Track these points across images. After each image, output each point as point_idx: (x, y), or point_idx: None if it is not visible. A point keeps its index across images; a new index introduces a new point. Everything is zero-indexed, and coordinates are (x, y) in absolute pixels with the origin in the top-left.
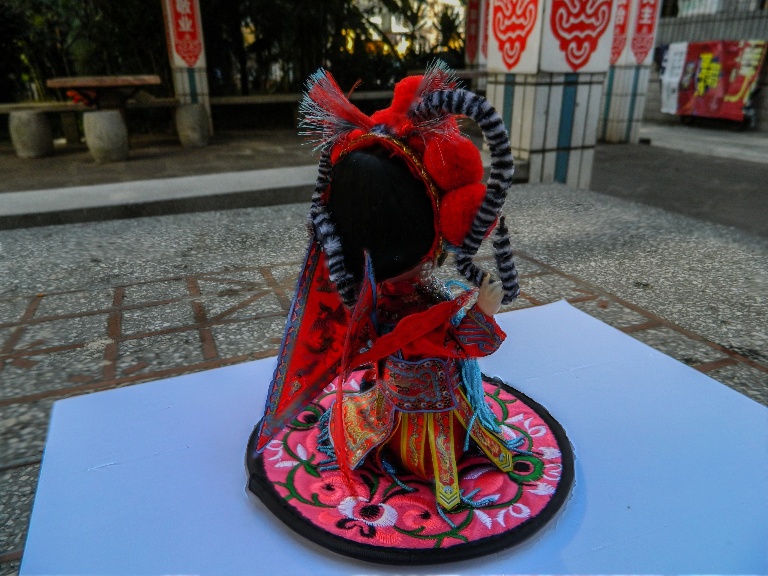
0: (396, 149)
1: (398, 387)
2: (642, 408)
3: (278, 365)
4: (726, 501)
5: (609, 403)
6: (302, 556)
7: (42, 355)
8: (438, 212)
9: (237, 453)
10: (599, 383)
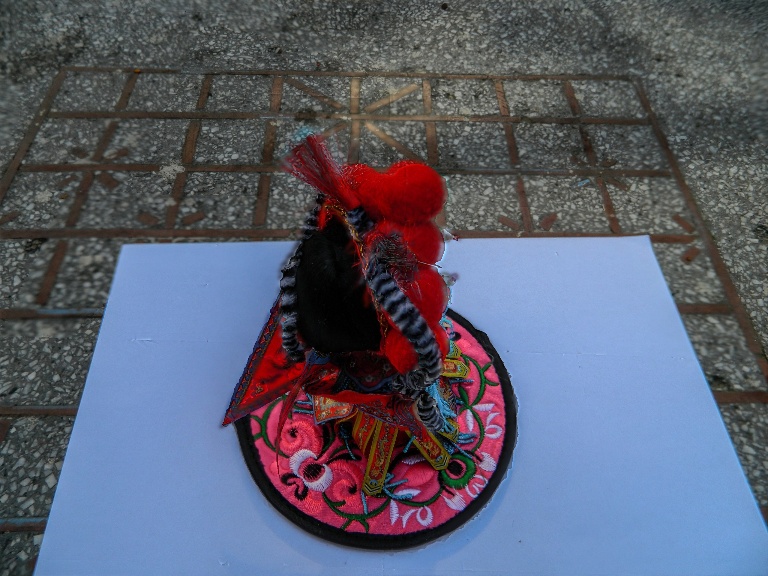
0: (360, 260)
1: None
2: (616, 432)
3: (244, 373)
4: (608, 568)
5: (588, 414)
6: (252, 489)
7: (124, 174)
8: (385, 338)
9: (242, 361)
10: (597, 383)
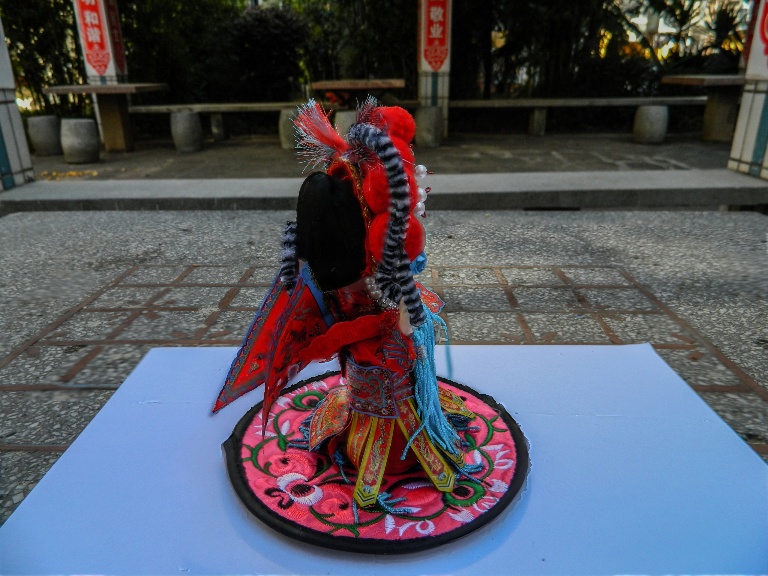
0: (349, 173)
1: (352, 387)
2: (645, 472)
3: (243, 346)
4: None
5: (610, 457)
6: (232, 507)
7: (167, 312)
8: None
9: None
10: (616, 435)
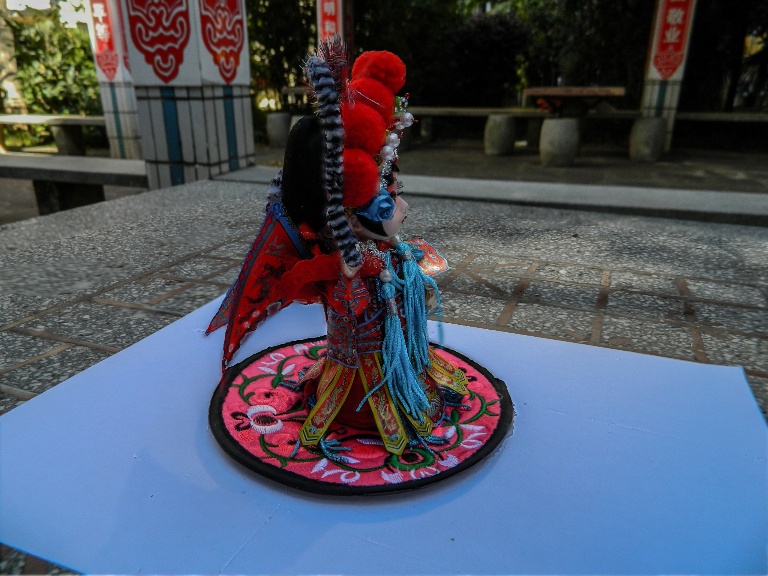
0: None
1: None
2: (635, 490)
3: None
4: None
5: (602, 467)
6: (204, 421)
7: None
8: None
9: None
10: (626, 448)
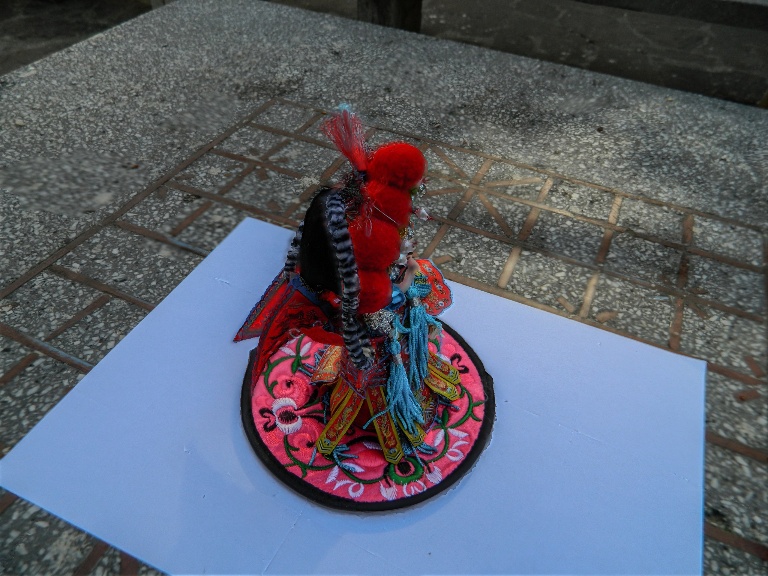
0: None
1: None
2: (576, 510)
3: (261, 300)
4: None
5: (556, 483)
6: (237, 410)
7: (275, 173)
8: None
9: None
10: (580, 462)
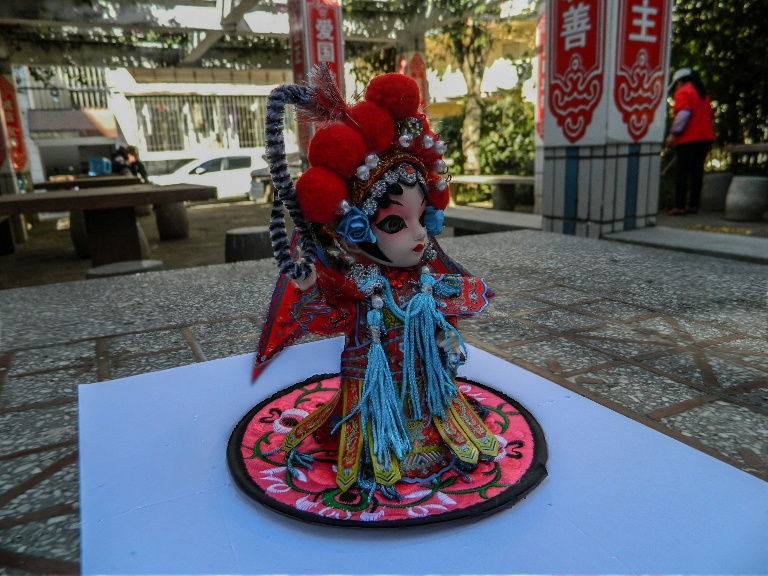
0: None
1: None
2: None
3: None
4: None
5: None
6: None
7: None
8: None
9: None
10: None
